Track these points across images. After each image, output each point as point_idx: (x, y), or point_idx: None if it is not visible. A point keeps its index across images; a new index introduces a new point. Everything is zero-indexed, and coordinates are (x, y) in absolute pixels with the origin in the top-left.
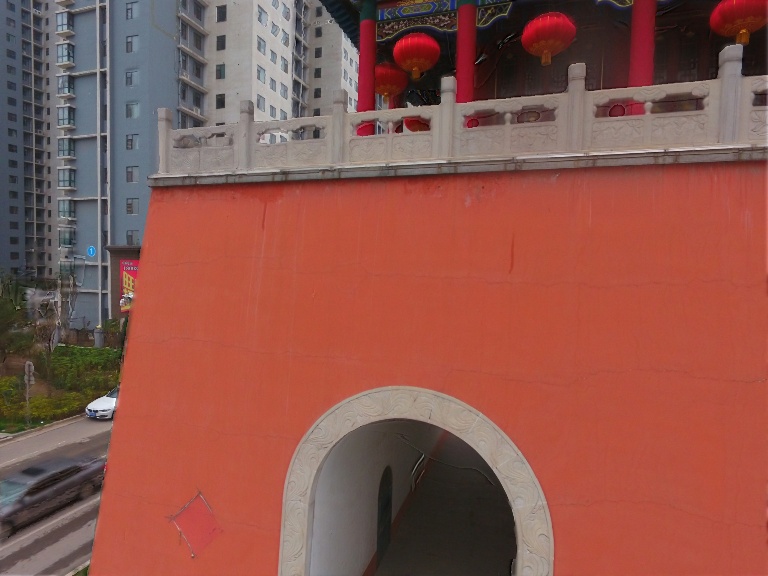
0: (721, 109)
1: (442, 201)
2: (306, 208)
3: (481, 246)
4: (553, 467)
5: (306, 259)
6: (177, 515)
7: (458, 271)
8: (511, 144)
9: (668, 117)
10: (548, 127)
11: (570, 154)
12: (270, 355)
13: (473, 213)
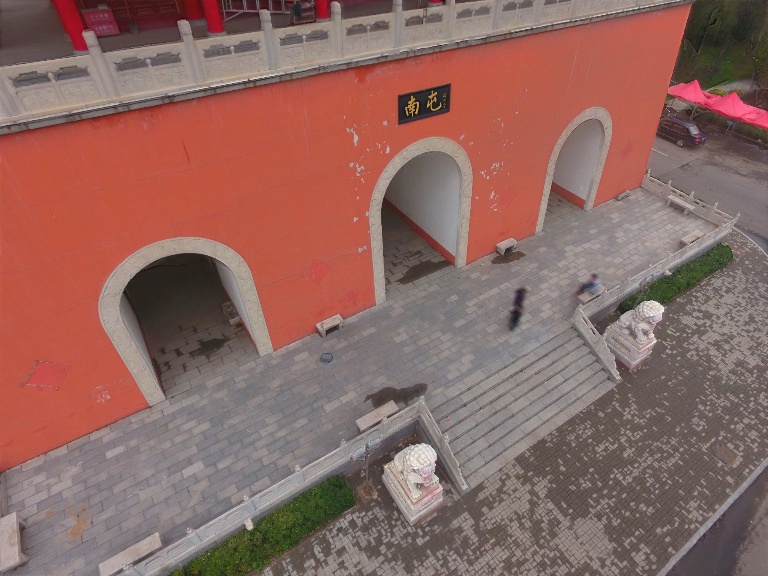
0: (268, 50)
1: (126, 129)
2: (6, 158)
3: (165, 152)
4: (241, 245)
5: (31, 195)
6: (28, 380)
7: (157, 171)
8: (158, 81)
9: (244, 56)
10: (179, 67)
11: (200, 88)
12: (42, 266)
13: (152, 133)
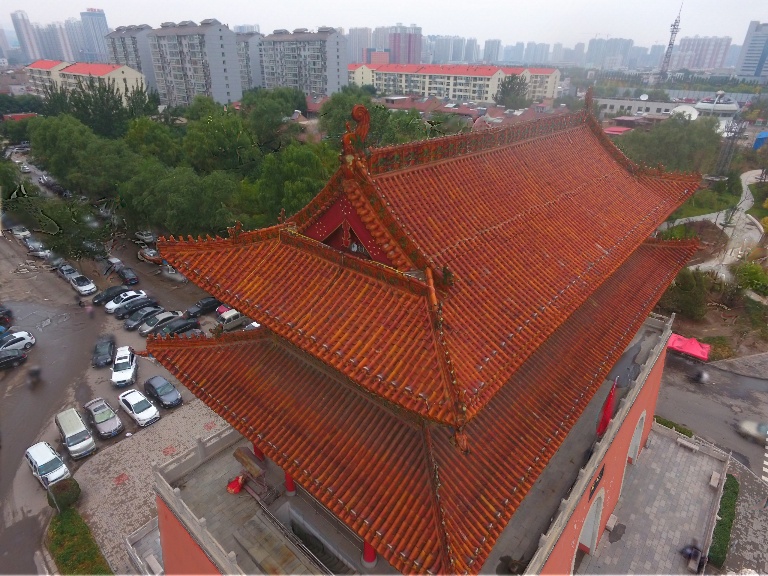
0: None
1: None
2: None
3: None
4: None
5: None
6: None
7: None
8: None
9: None
10: None
11: None
12: None
13: None
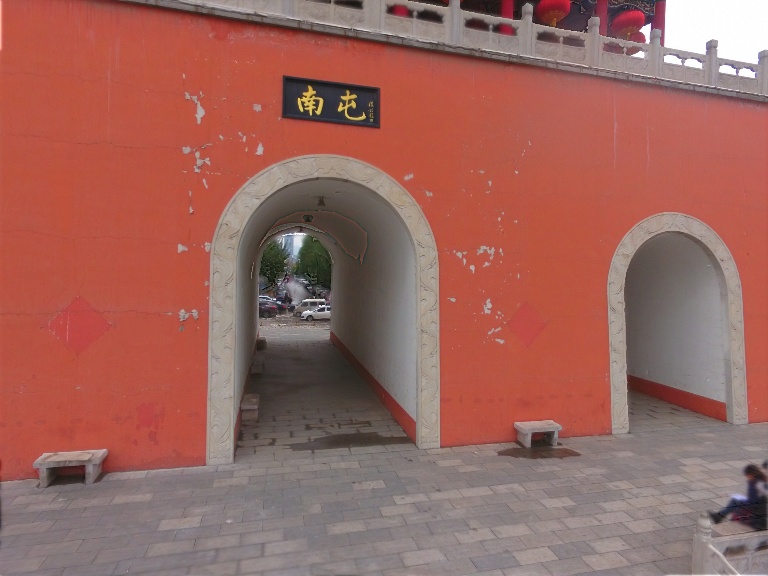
0: None
1: None
2: None
3: None
4: None
5: None
6: None
7: None
8: None
9: None
10: None
11: None
12: None
13: None
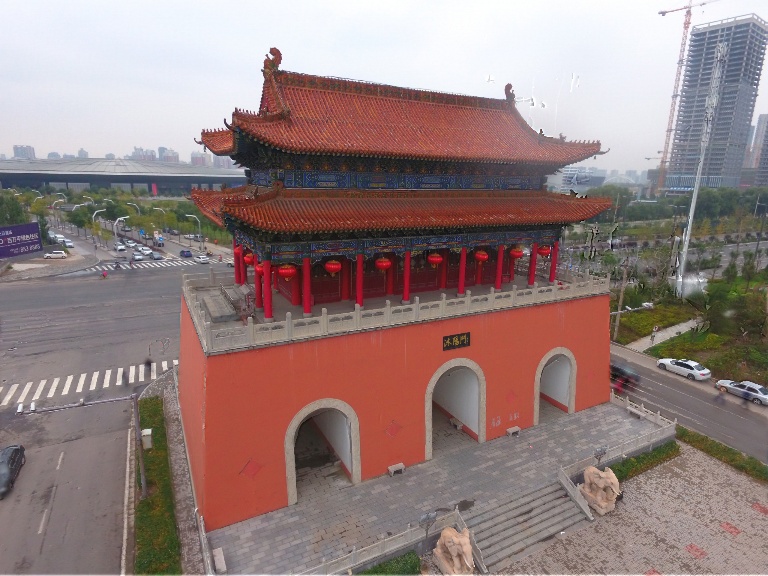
0: None
1: None
2: None
3: None
4: None
5: None
6: None
7: None
8: None
9: None
10: None
11: None
12: None
13: None
